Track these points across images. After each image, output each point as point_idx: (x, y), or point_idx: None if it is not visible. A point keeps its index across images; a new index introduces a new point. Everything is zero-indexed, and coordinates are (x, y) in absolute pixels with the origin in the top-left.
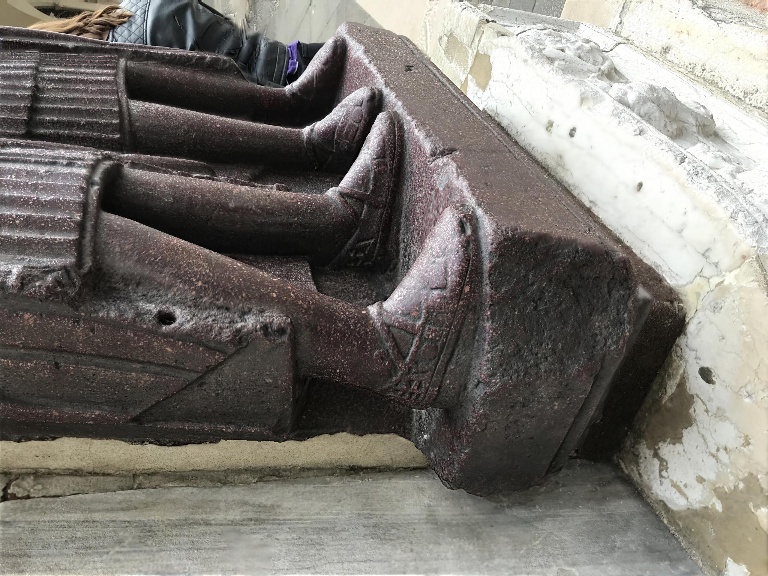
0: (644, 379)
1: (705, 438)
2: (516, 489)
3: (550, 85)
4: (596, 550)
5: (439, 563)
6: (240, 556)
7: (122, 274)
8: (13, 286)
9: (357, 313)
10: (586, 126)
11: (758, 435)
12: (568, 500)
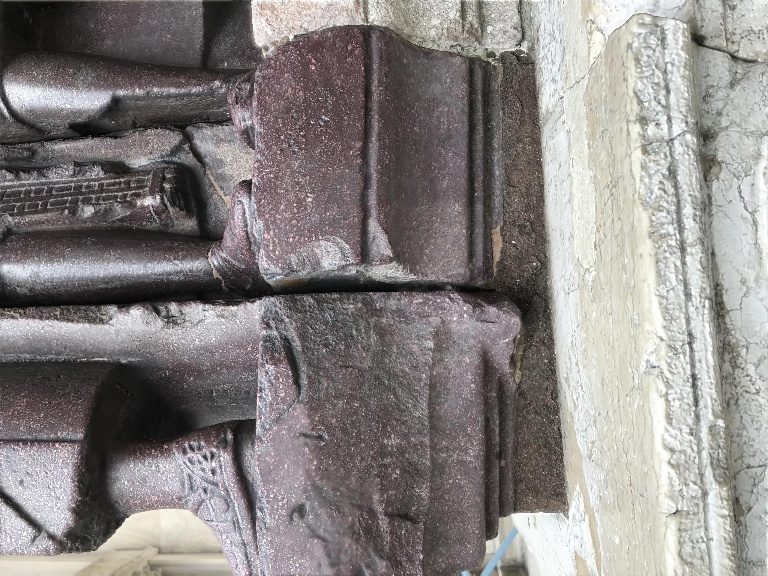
0: None
1: None
2: None
3: (545, 574)
4: None
5: None
6: None
7: None
8: None
9: None
10: (528, 533)
11: None
12: None
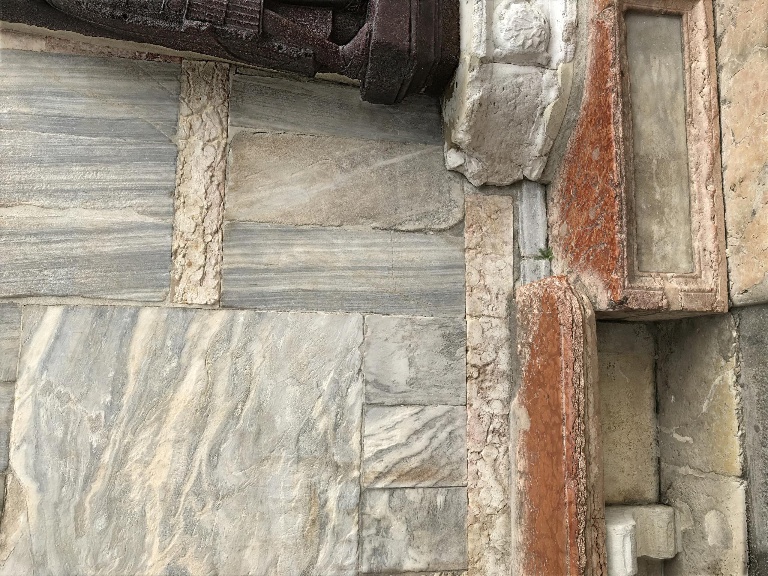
0: (447, 77)
1: (452, 104)
2: (385, 104)
3: None
4: (410, 127)
5: (356, 119)
6: (299, 104)
7: (269, 33)
8: (244, 39)
9: (335, 50)
10: None
11: (457, 109)
12: (411, 109)
